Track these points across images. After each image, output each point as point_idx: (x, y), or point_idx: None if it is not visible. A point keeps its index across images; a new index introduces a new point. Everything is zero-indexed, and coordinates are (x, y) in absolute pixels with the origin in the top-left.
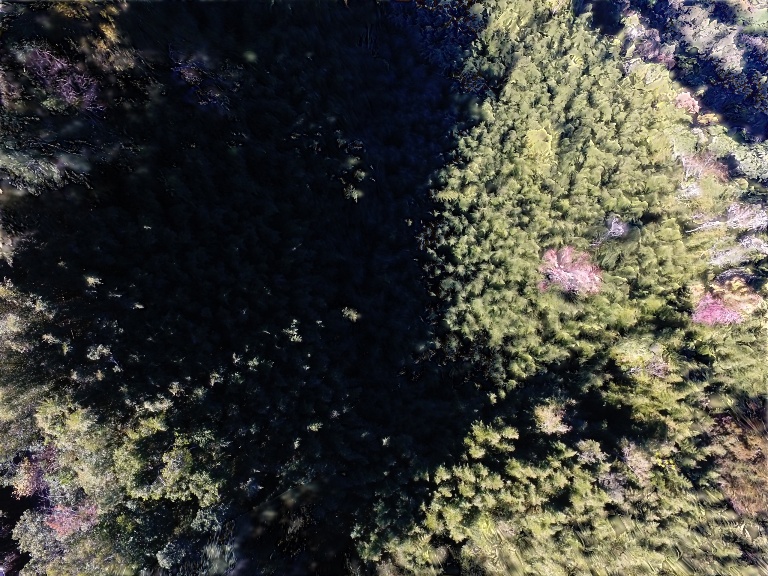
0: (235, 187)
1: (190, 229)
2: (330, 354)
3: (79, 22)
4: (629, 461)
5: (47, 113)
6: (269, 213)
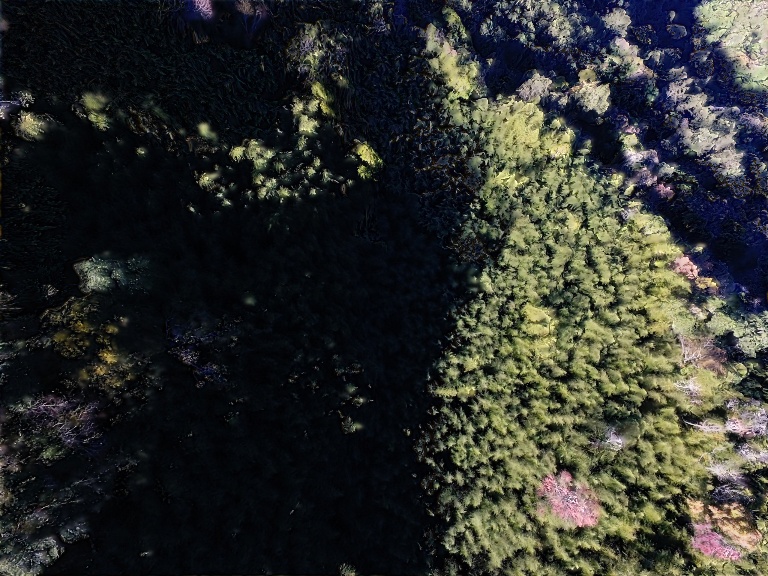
0: (232, 463)
1: (187, 533)
2: None
3: (75, 361)
4: None
5: (43, 467)
6: (267, 478)
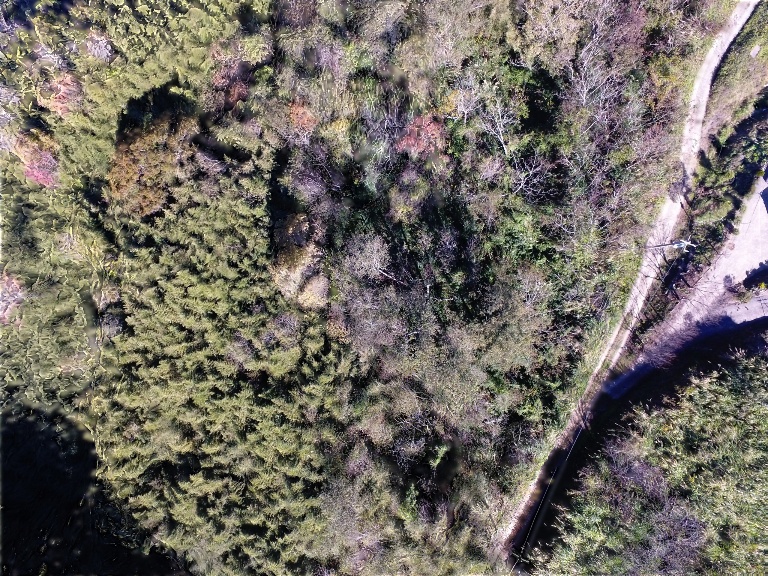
0: None
1: None
2: (9, 541)
3: None
4: None
5: None
6: None
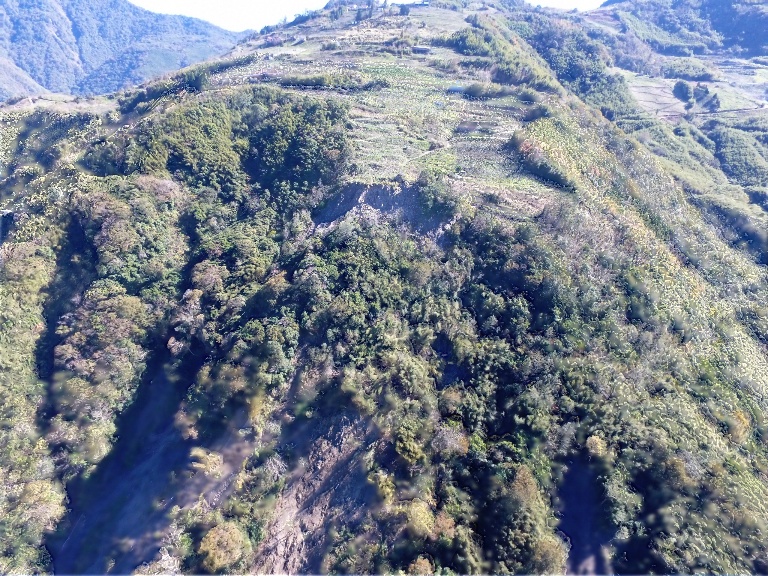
0: None
1: None
2: None
3: None
4: (2, 119)
5: None
6: None
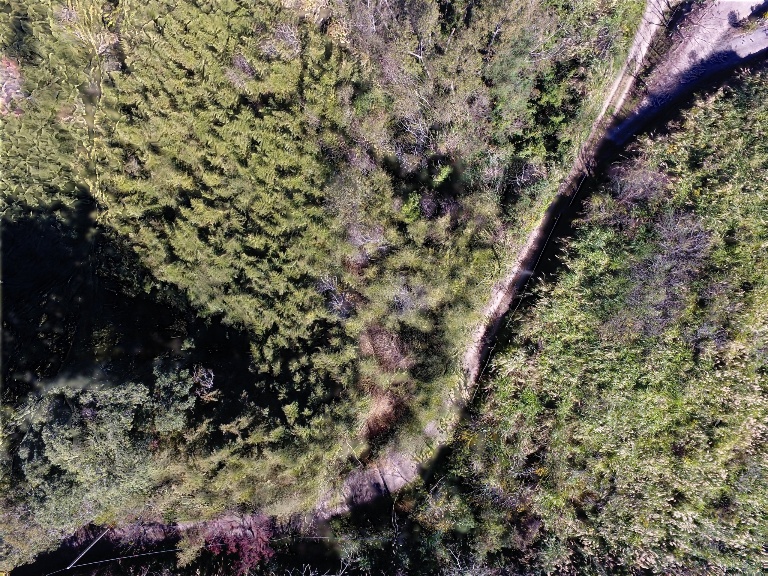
0: None
1: None
2: (9, 305)
3: None
4: None
5: None
6: None
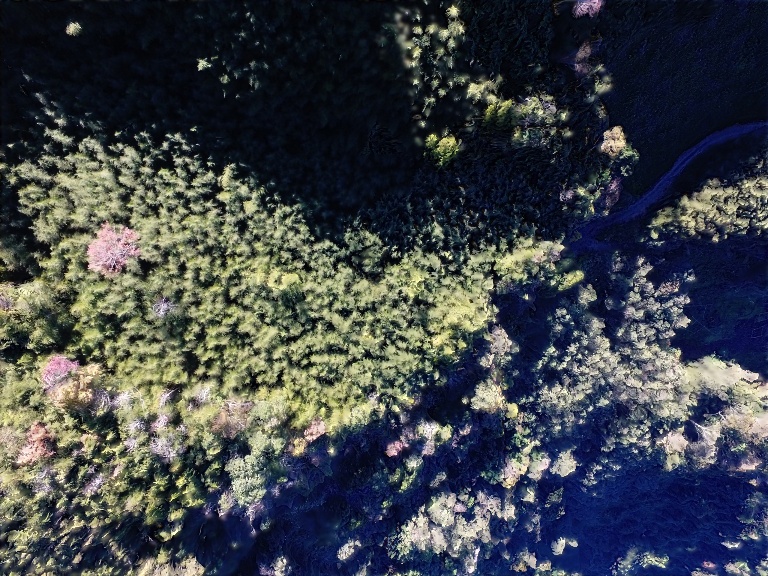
0: None
1: None
2: None
3: None
4: None
5: None
6: None
